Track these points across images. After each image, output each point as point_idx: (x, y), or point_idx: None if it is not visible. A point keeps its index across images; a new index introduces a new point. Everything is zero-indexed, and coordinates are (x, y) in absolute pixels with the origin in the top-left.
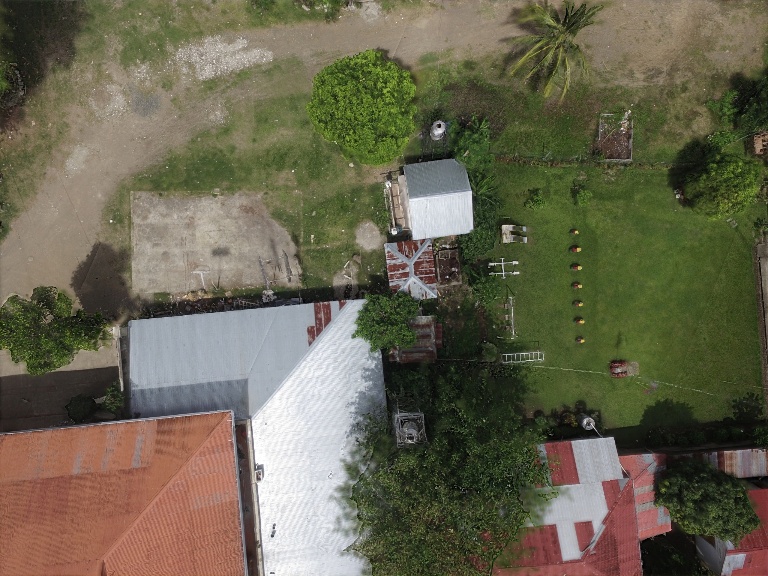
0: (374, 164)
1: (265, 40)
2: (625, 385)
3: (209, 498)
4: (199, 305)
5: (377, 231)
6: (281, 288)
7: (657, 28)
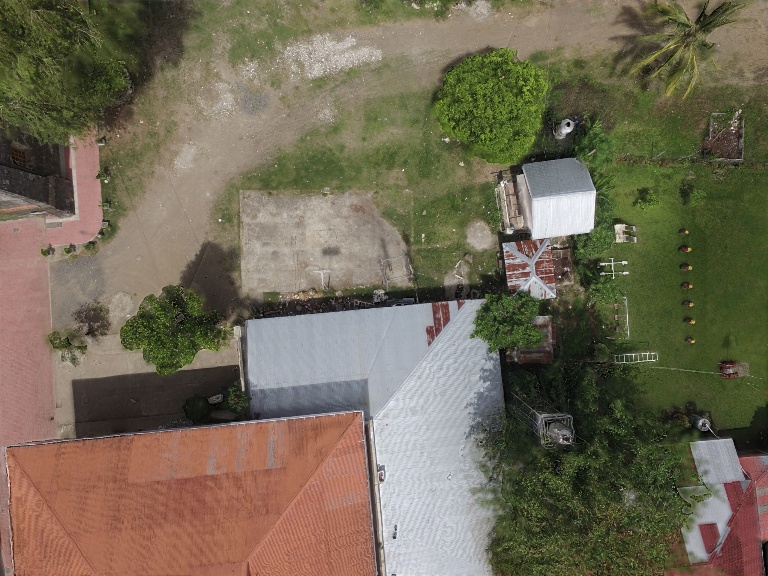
0: (501, 163)
1: (374, 38)
2: (735, 386)
3: (342, 499)
4: (309, 305)
5: (488, 231)
6: (392, 288)
7: (767, 27)
